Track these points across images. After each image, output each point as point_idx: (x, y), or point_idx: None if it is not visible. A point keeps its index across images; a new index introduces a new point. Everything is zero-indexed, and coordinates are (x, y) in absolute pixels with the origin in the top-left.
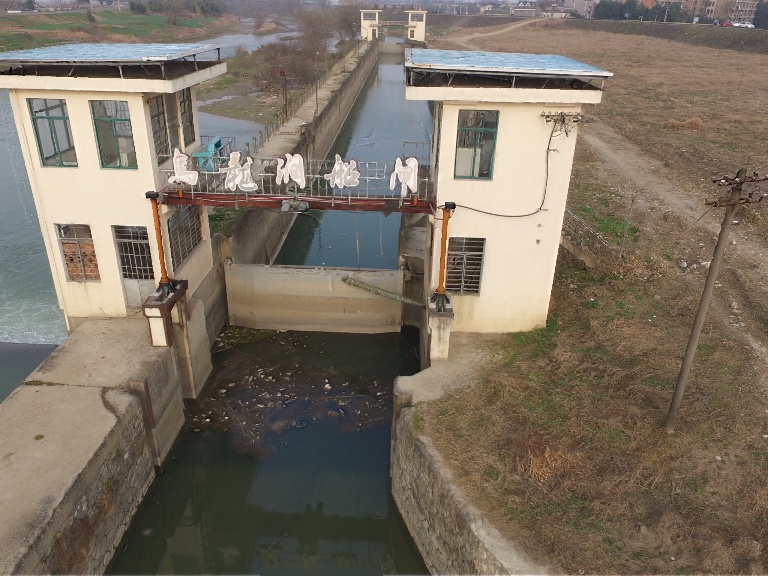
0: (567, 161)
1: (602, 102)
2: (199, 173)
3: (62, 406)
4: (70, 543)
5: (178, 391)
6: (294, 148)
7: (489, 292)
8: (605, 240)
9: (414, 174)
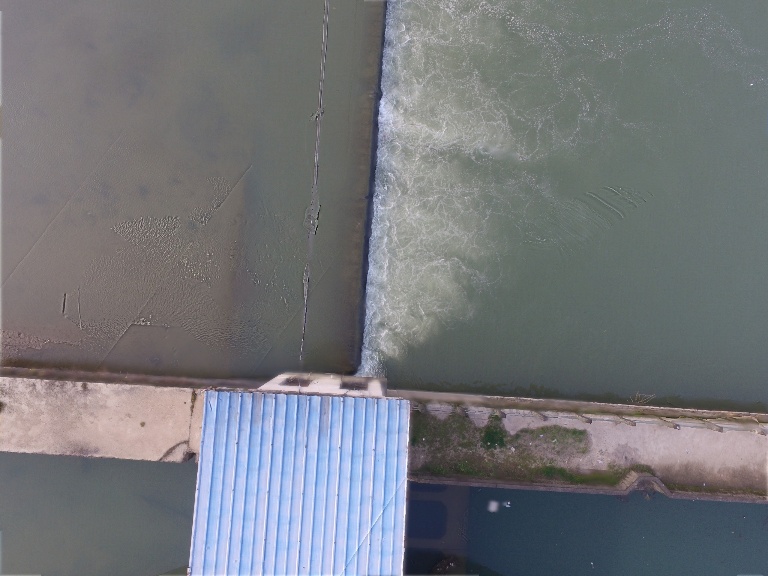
0: None
1: None
2: None
3: (170, 424)
4: None
5: None
6: (763, 502)
7: None
8: None
9: None
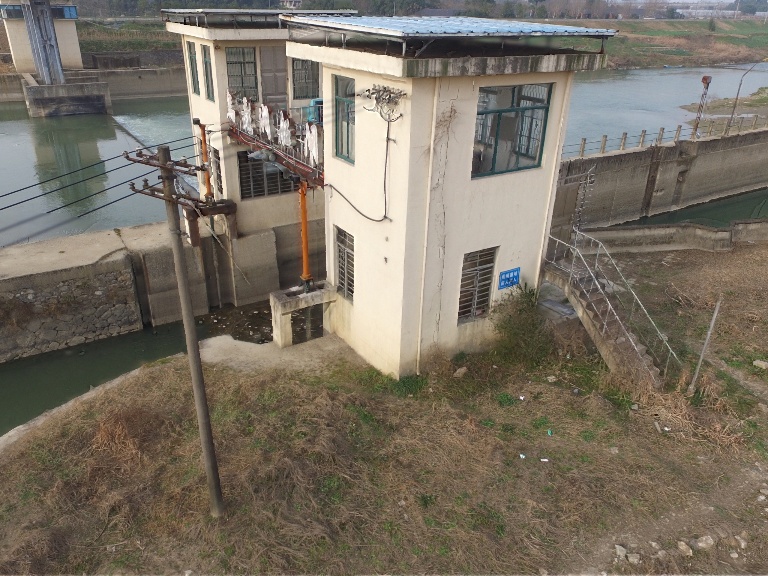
0: (405, 159)
1: (404, 75)
2: (238, 113)
3: (97, 245)
4: (4, 308)
5: (201, 286)
6: None
7: (359, 305)
8: (760, 372)
9: (316, 143)
